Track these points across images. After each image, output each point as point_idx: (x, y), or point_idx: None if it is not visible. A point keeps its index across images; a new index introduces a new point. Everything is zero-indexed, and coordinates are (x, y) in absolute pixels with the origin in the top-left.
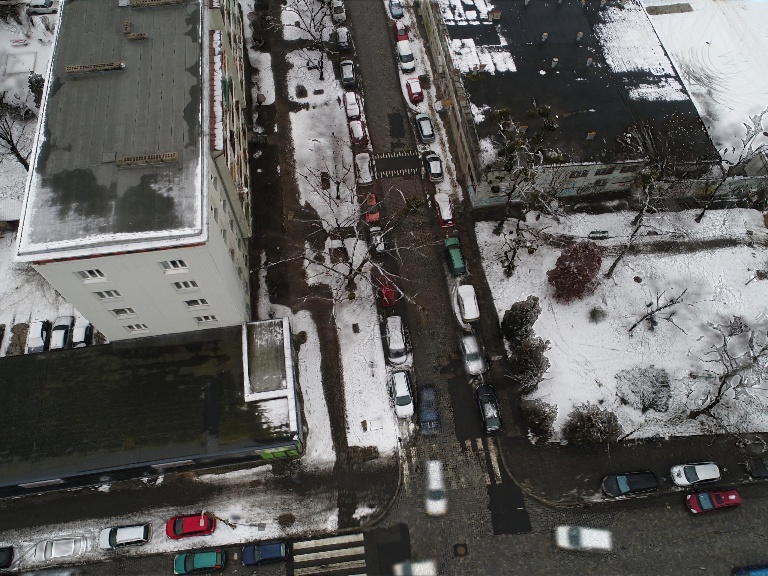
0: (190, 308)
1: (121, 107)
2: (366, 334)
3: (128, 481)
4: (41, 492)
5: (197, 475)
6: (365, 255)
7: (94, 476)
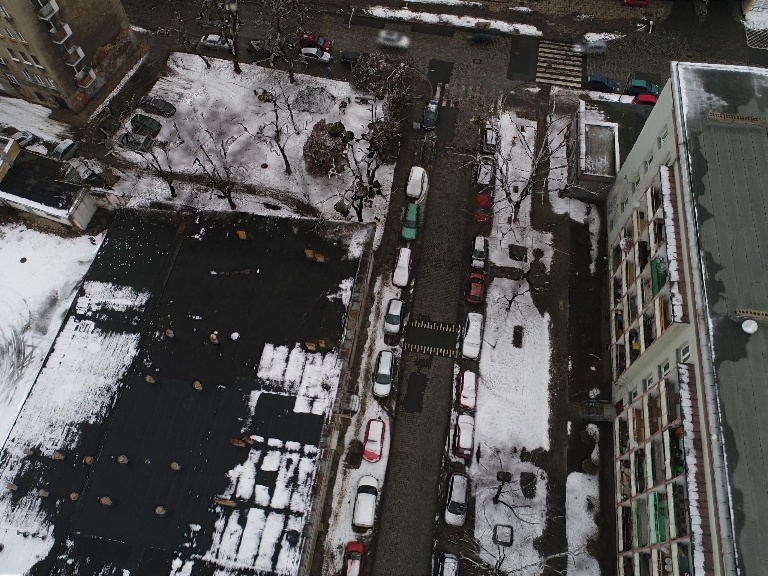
0: None
1: None
2: None
3: None
4: None
5: None
6: None
7: None
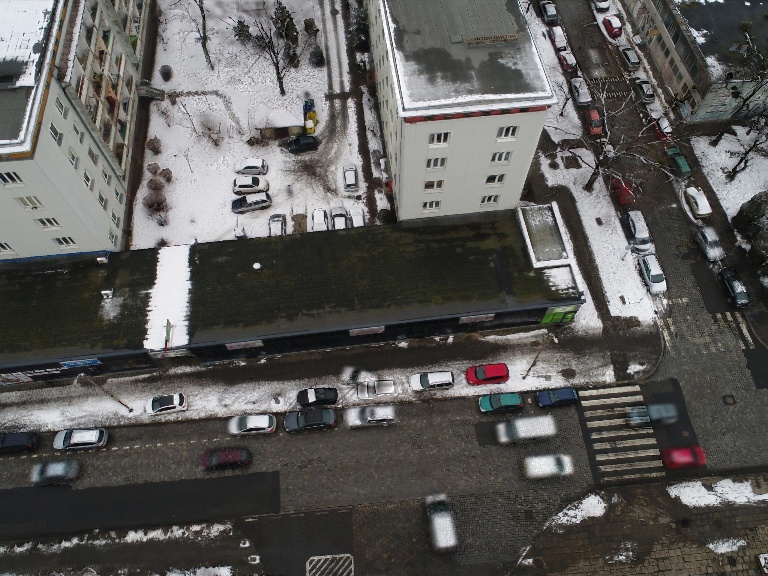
0: (486, 185)
1: (452, 1)
2: (609, 226)
3: (423, 339)
4: (350, 346)
5: (482, 336)
6: (614, 153)
7: (407, 327)
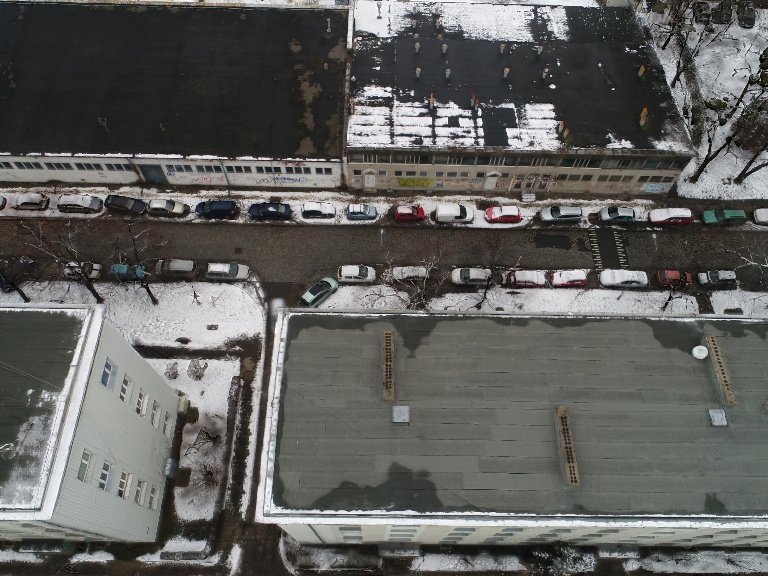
0: None
1: None
2: None
3: None
4: None
5: None
6: None
7: None
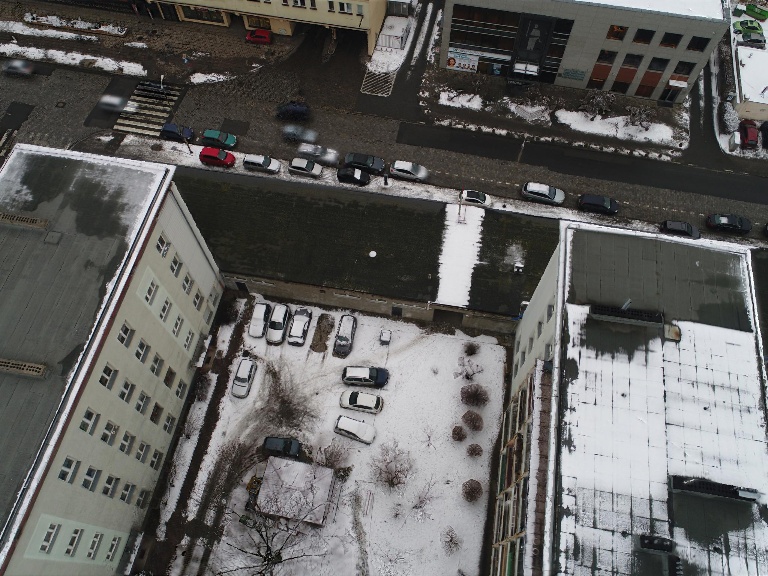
0: None
1: (12, 301)
2: None
3: None
4: None
5: None
6: None
7: None
